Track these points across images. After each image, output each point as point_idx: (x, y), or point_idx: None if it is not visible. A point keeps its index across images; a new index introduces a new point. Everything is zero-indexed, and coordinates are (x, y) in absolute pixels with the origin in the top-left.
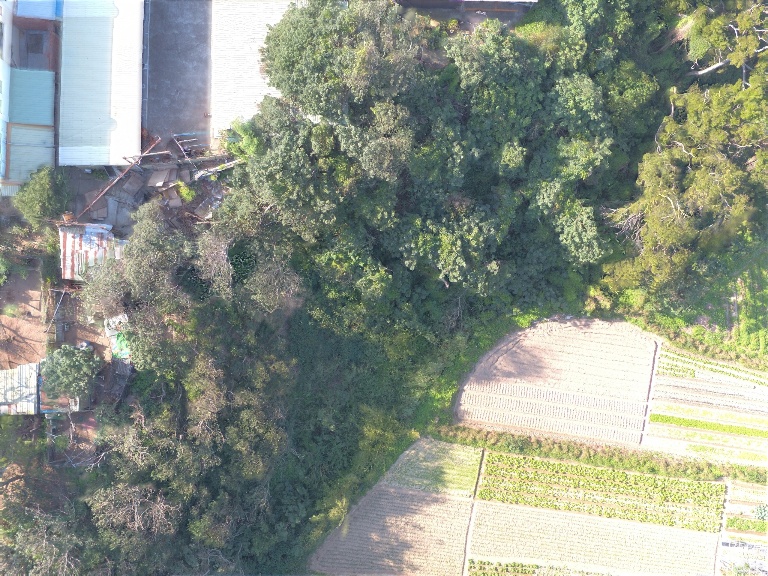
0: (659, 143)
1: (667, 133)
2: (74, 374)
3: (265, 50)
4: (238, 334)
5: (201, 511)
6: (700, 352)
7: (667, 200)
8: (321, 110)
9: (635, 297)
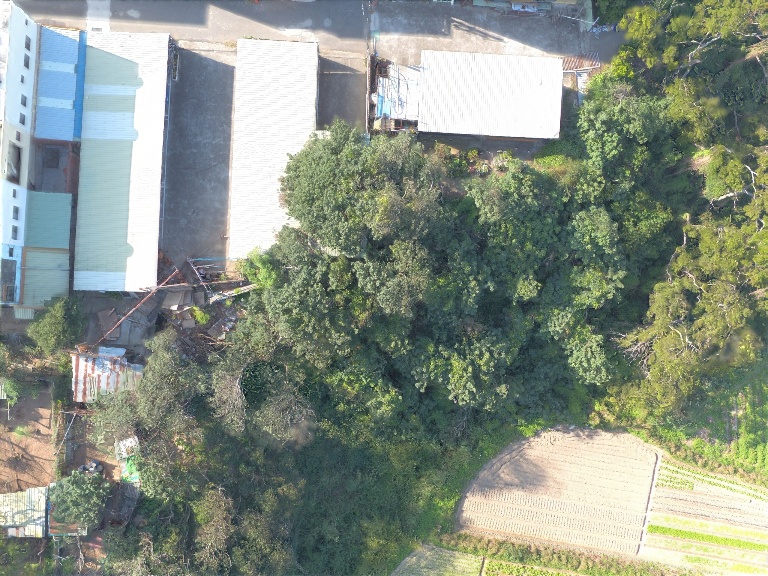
0: (670, 273)
1: (679, 265)
2: (84, 504)
3: (285, 180)
4: (247, 450)
5: None
6: (699, 466)
7: (676, 333)
8: (340, 246)
9: (638, 409)
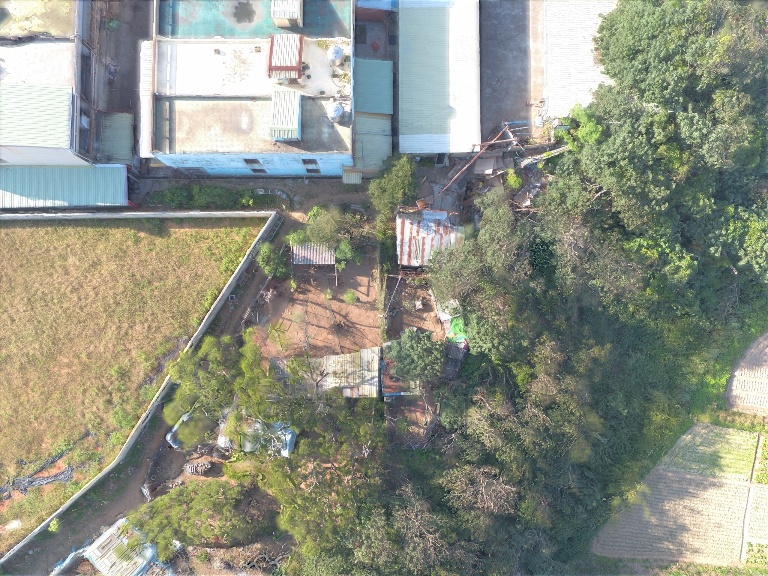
0: None
1: None
2: (427, 357)
3: (599, 39)
4: (546, 319)
5: (525, 493)
6: None
7: None
8: (662, 98)
9: None
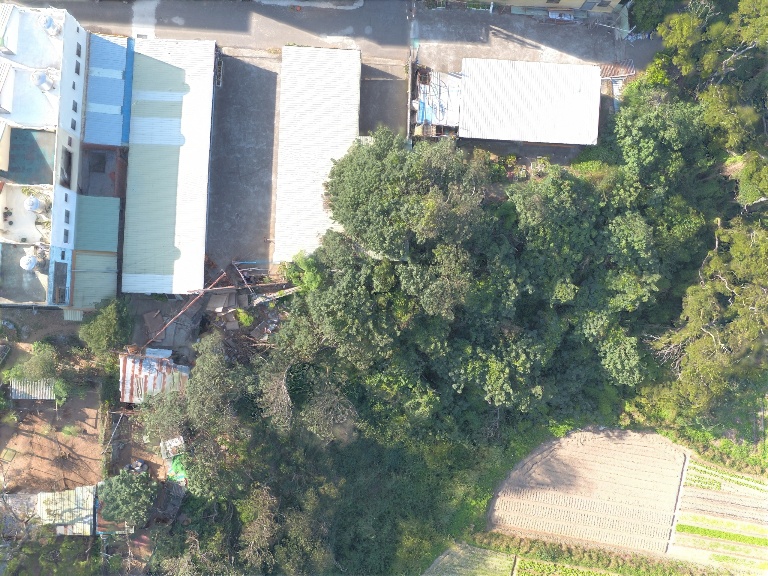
0: (703, 277)
1: (711, 268)
2: (133, 502)
3: (329, 184)
4: (287, 450)
5: None
6: (727, 466)
7: (709, 335)
8: (383, 249)
9: (667, 410)
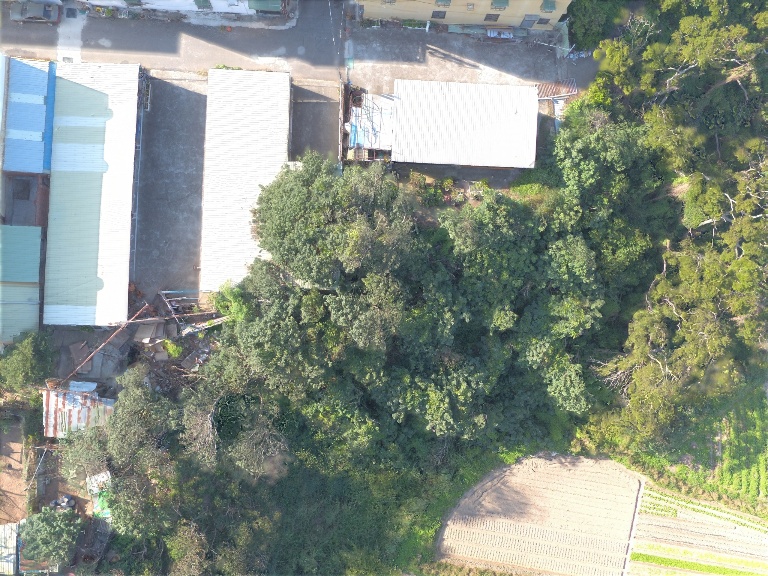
0: (650, 301)
1: (658, 293)
2: (54, 542)
3: (257, 211)
4: (222, 482)
5: None
6: (683, 493)
7: (656, 362)
8: (312, 278)
9: (621, 435)
